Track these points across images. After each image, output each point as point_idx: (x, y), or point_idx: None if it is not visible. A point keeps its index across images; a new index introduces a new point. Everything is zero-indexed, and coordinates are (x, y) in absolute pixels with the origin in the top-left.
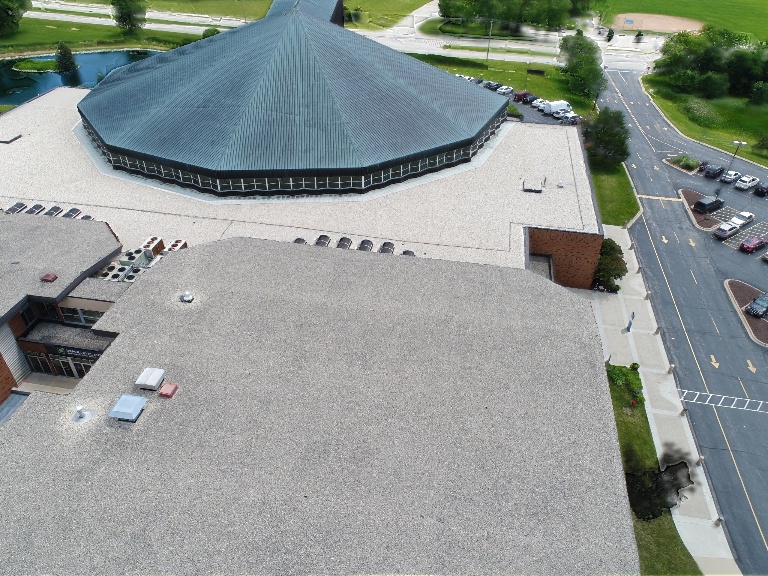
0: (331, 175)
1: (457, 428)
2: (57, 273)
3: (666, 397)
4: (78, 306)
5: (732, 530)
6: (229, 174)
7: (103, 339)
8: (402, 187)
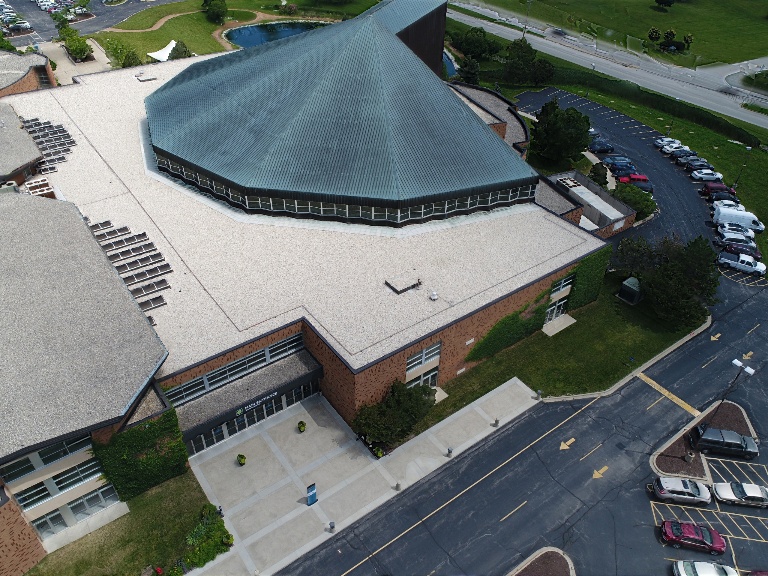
0: (223, 183)
1: None
2: None
3: None
4: None
5: None
6: (160, 151)
7: None
8: (289, 223)
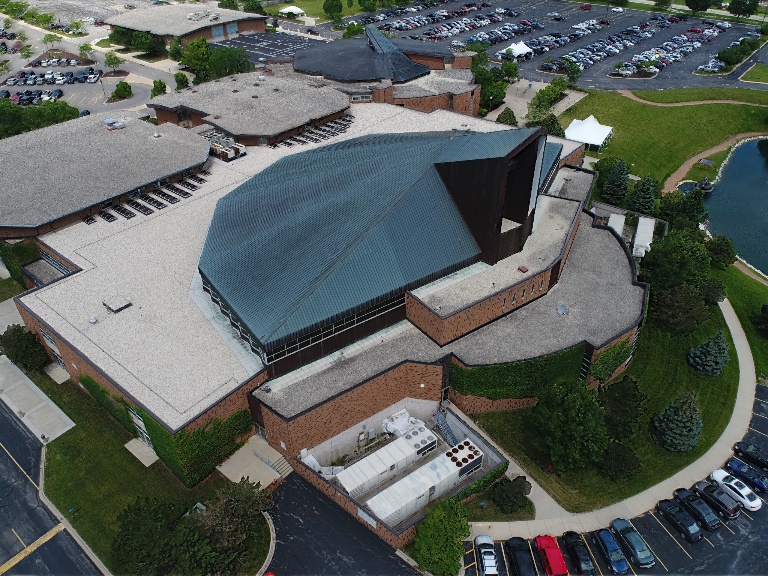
0: None
1: (2, 164)
2: (220, 119)
3: None
4: None
5: None
6: None
7: None
8: None
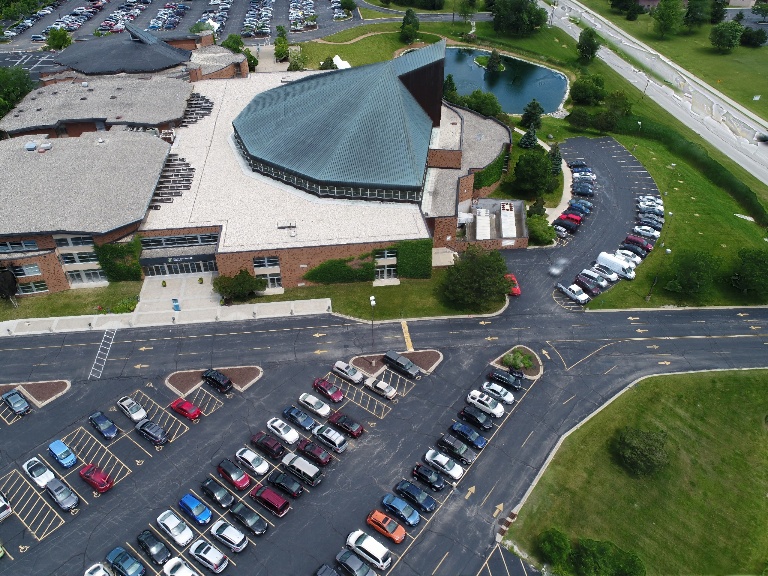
0: None
1: None
2: None
3: (108, 323)
4: None
5: (7, 340)
6: None
7: None
8: (267, 181)
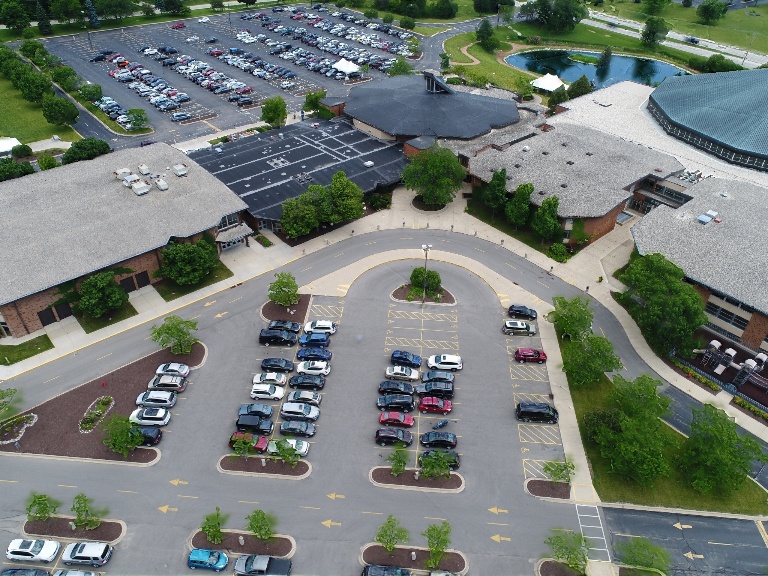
0: None
1: None
2: None
3: None
4: (666, 186)
5: None
6: (743, 152)
7: (670, 203)
8: None
